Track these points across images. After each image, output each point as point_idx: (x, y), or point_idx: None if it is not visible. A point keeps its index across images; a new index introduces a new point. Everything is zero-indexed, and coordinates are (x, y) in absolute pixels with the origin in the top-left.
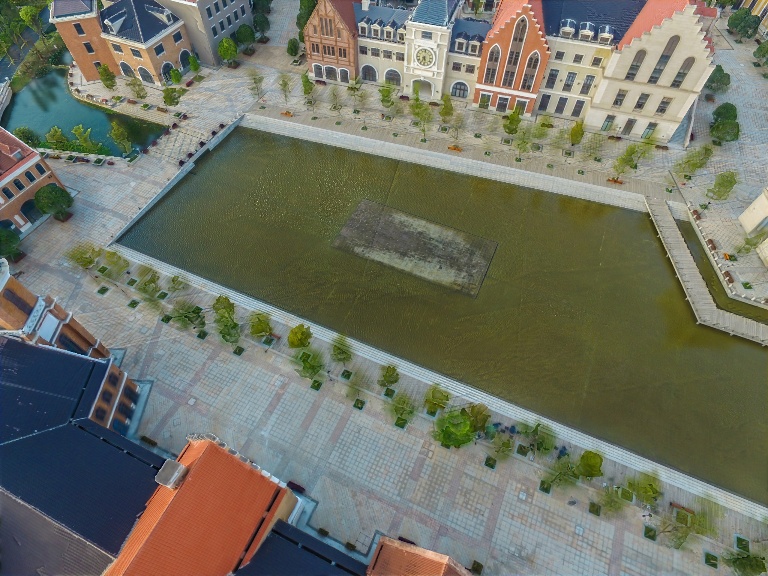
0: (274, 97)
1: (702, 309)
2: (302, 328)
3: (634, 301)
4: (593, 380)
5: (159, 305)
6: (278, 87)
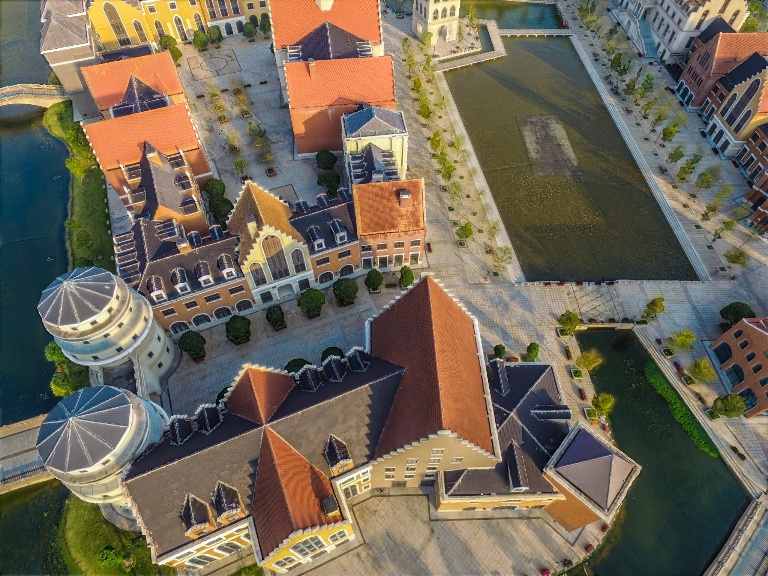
0: (474, 274)
1: (499, 54)
2: (669, 127)
3: (510, 72)
4: (564, 78)
5: (704, 225)
6: (457, 279)
